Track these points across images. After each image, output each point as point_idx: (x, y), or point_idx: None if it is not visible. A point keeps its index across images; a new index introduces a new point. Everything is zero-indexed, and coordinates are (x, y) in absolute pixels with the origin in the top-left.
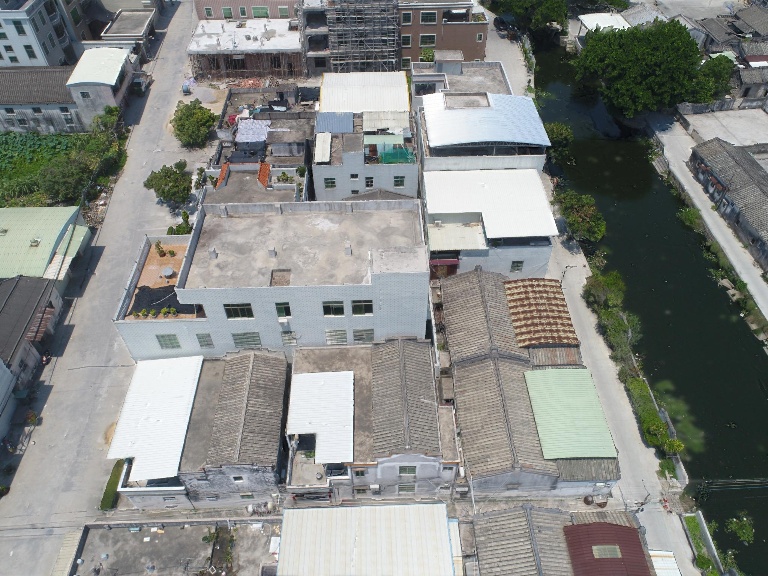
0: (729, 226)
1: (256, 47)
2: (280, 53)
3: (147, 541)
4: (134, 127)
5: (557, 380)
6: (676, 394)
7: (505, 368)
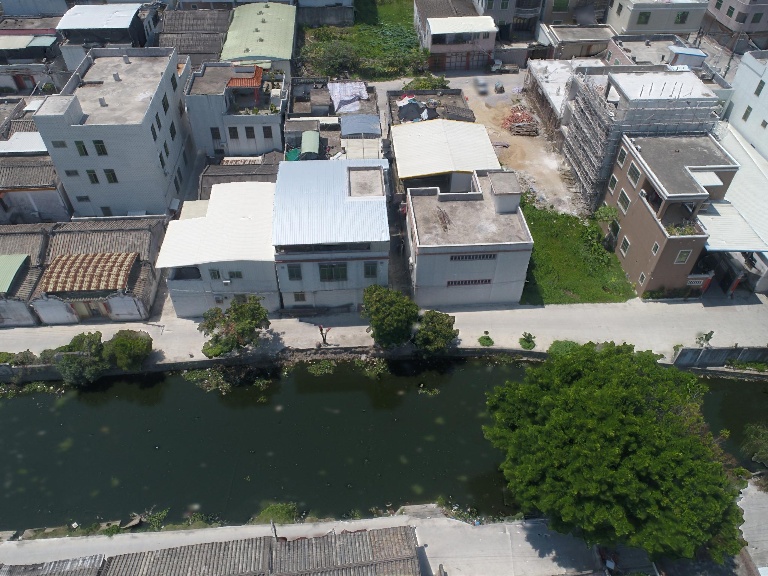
0: None
1: (551, 92)
2: (553, 109)
3: (5, 118)
4: (434, 77)
5: (5, 269)
6: (1, 414)
7: (35, 241)
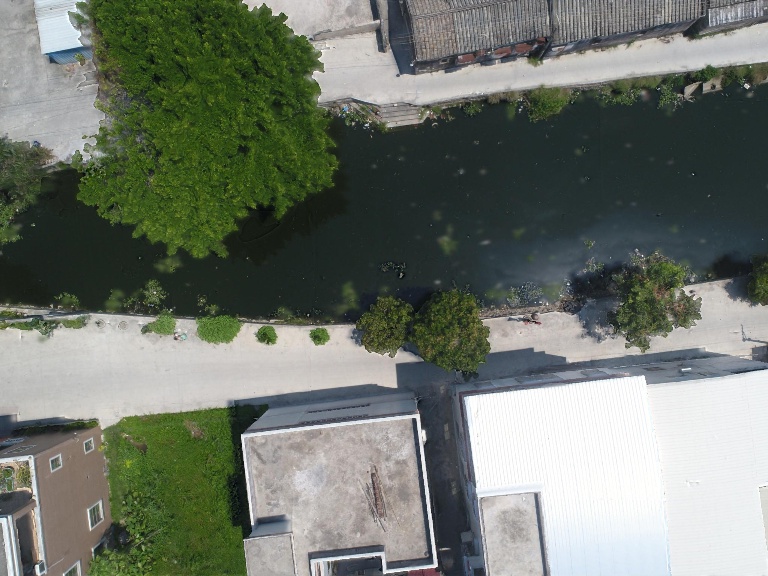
0: (584, 52)
1: None
2: None
3: None
4: None
5: None
6: None
7: None
